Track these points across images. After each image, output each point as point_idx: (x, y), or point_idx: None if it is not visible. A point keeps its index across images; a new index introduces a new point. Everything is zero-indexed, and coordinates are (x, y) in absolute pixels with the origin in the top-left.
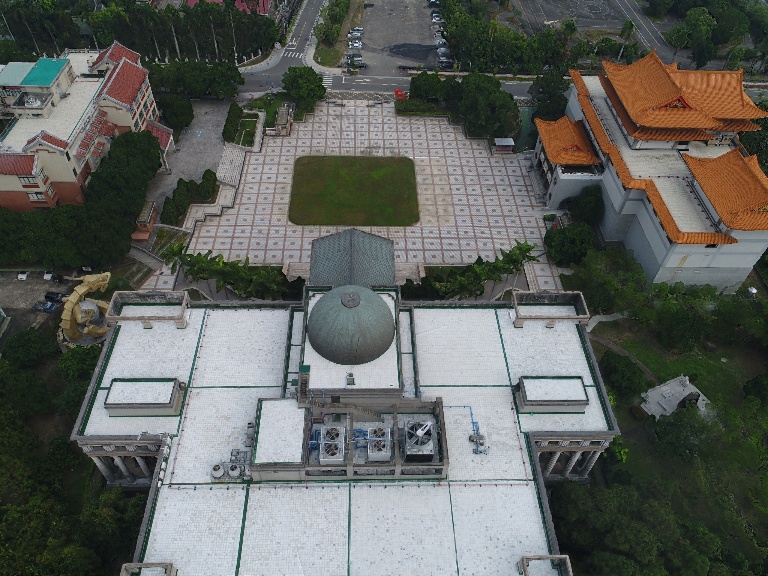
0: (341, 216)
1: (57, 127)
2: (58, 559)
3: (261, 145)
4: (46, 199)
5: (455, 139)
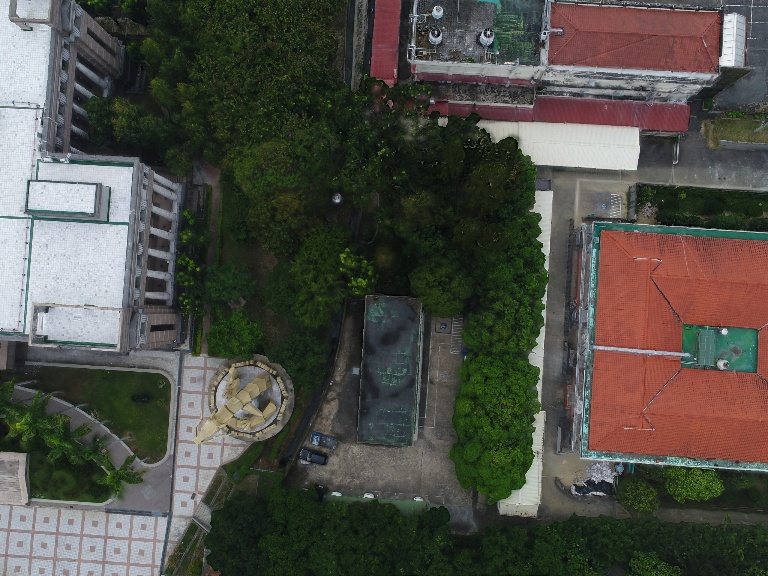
0: None
1: None
2: None
3: None
4: None
5: None
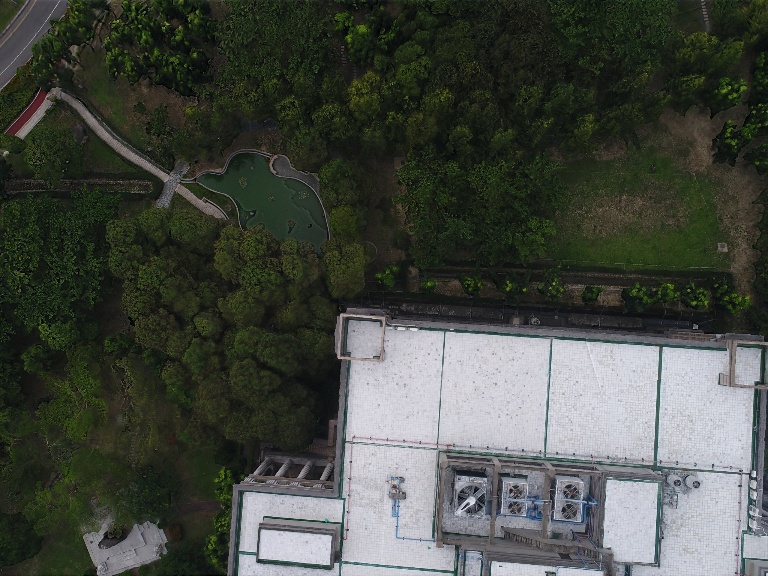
0: None
1: None
2: None
3: None
4: None
5: None
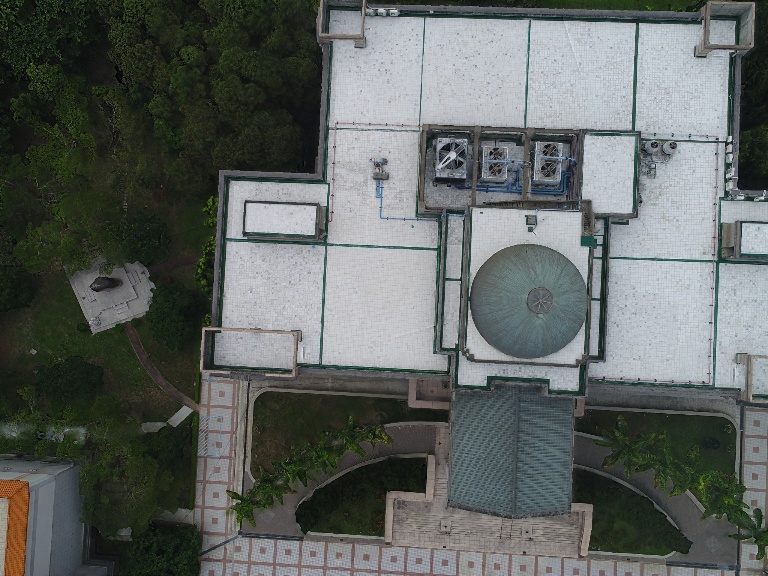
0: None
1: None
2: None
3: None
4: None
5: None
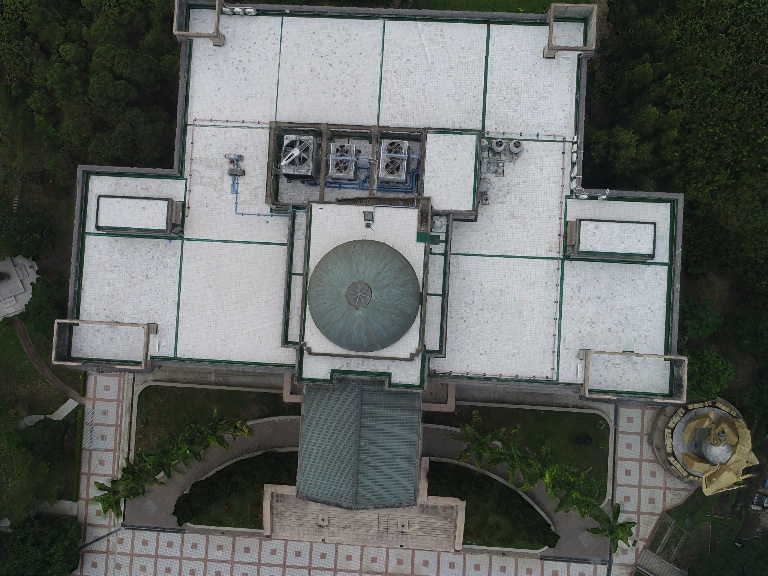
0: None
1: None
2: (662, 119)
3: None
4: None
5: None
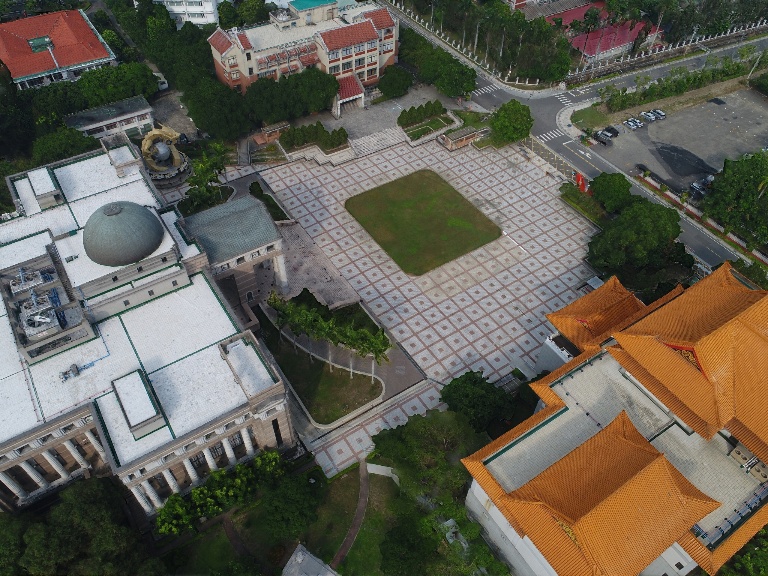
0: (377, 225)
1: (276, 39)
2: None
3: (422, 143)
4: (229, 78)
5: (570, 251)
